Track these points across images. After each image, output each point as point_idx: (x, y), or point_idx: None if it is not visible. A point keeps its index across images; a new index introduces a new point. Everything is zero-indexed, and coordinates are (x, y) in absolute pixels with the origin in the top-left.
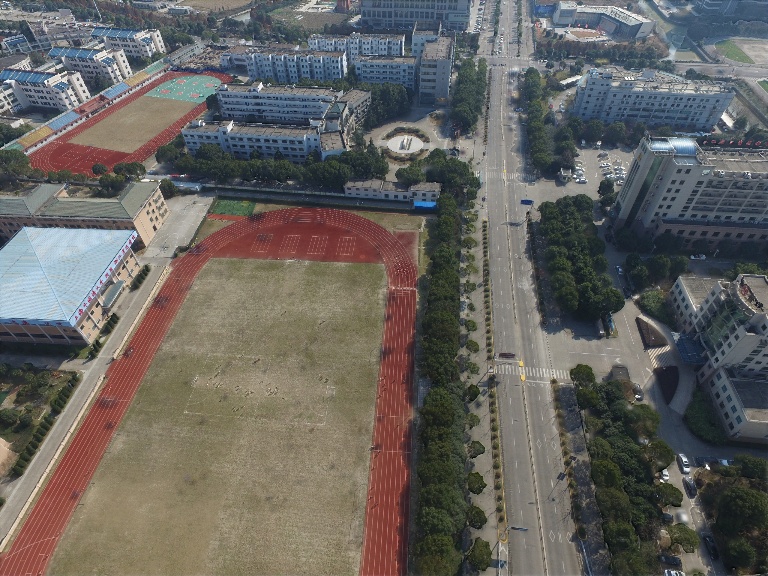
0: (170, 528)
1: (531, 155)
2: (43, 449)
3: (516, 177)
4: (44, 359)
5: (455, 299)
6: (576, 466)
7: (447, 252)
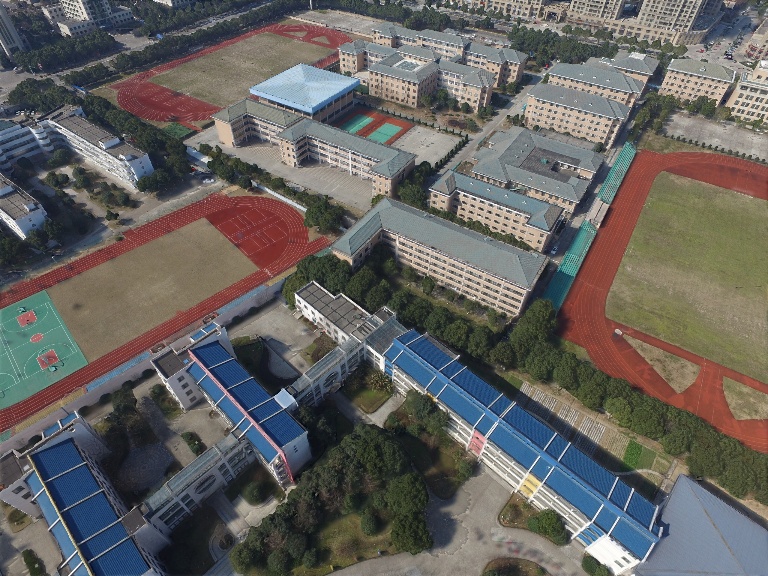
0: None
1: None
2: None
3: None
4: None
5: None
6: None
7: (122, 54)
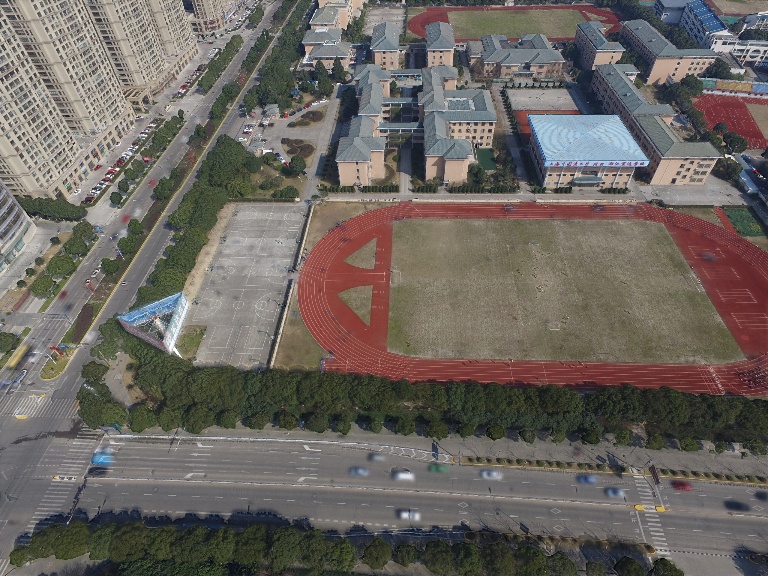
0: (433, 259)
1: None
2: (467, 195)
3: None
4: (524, 174)
5: (717, 420)
6: (540, 549)
7: None
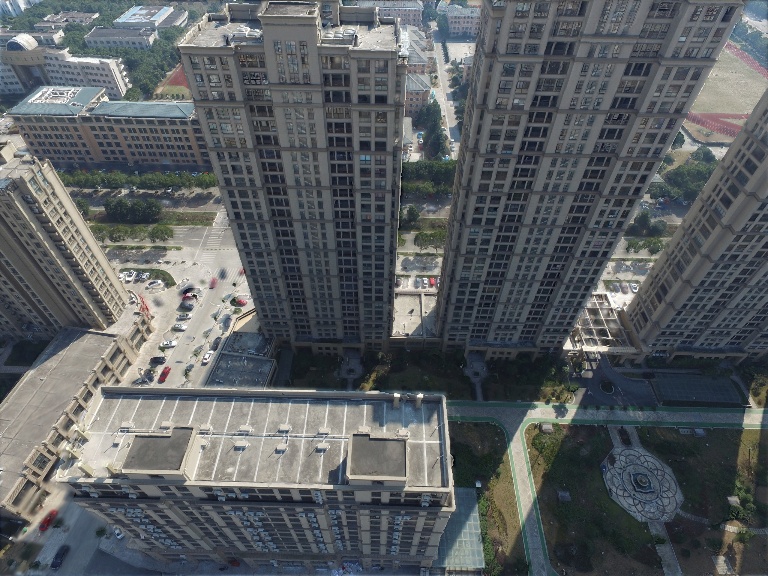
0: None
1: (754, 8)
2: None
3: (749, 19)
4: None
5: None
6: None
7: None
